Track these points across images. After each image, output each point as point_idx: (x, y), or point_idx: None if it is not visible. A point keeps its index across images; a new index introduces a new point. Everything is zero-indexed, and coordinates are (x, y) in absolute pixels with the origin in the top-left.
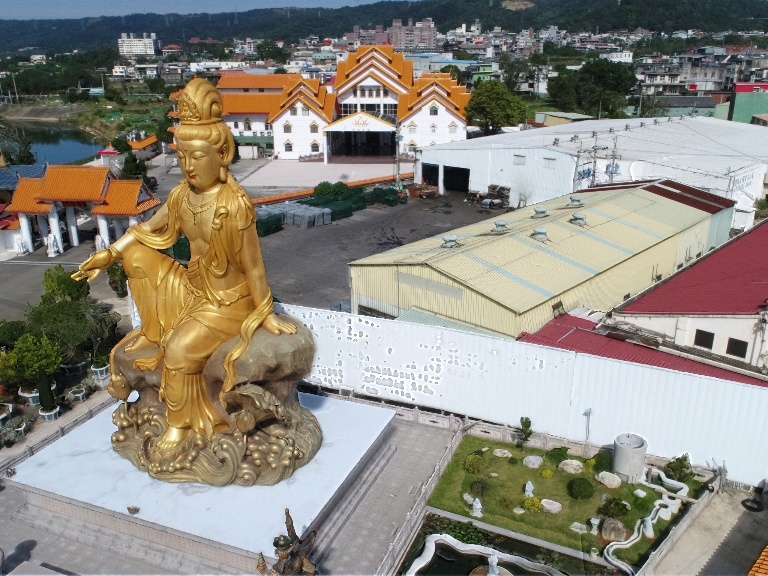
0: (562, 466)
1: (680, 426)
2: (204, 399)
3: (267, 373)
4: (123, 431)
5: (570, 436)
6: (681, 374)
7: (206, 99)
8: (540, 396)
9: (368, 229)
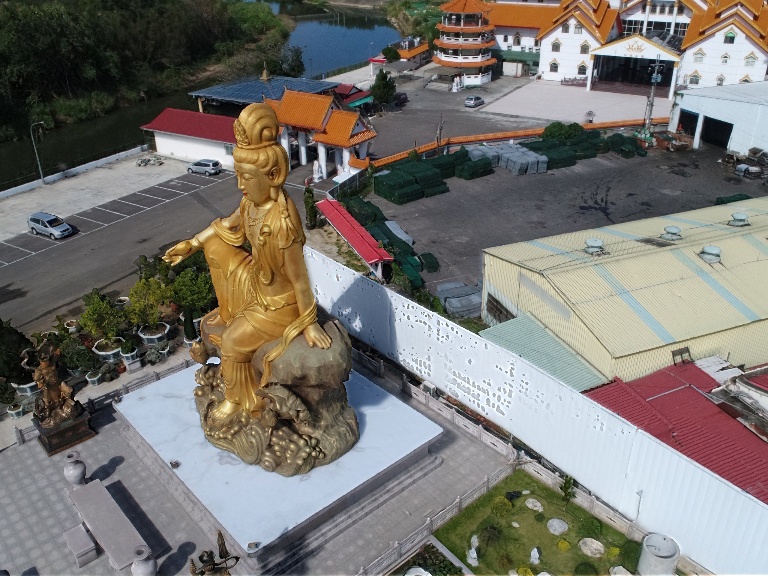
0: (581, 543)
1: (734, 548)
2: (252, 384)
3: (295, 379)
4: (203, 387)
5: (622, 508)
6: (743, 495)
7: (256, 125)
8: (598, 457)
9: (581, 185)
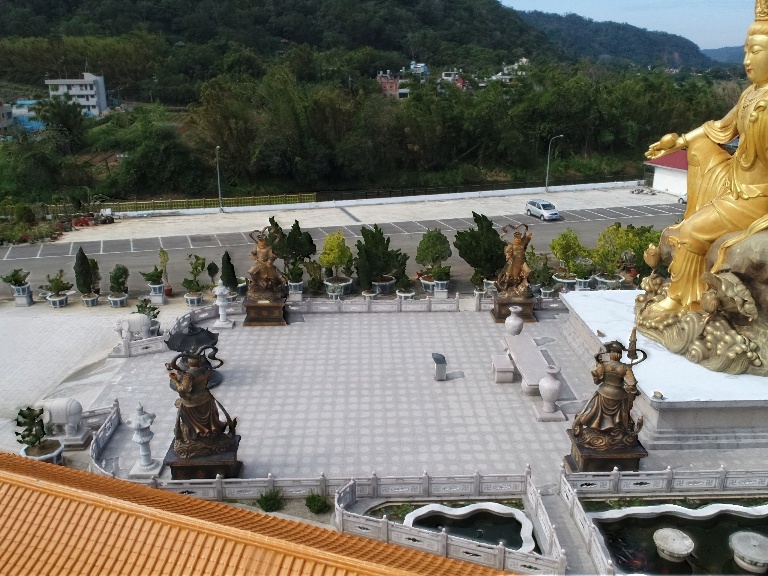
0: None
1: None
2: (700, 281)
3: (751, 268)
4: (646, 295)
5: None
6: None
7: None
8: None
9: None
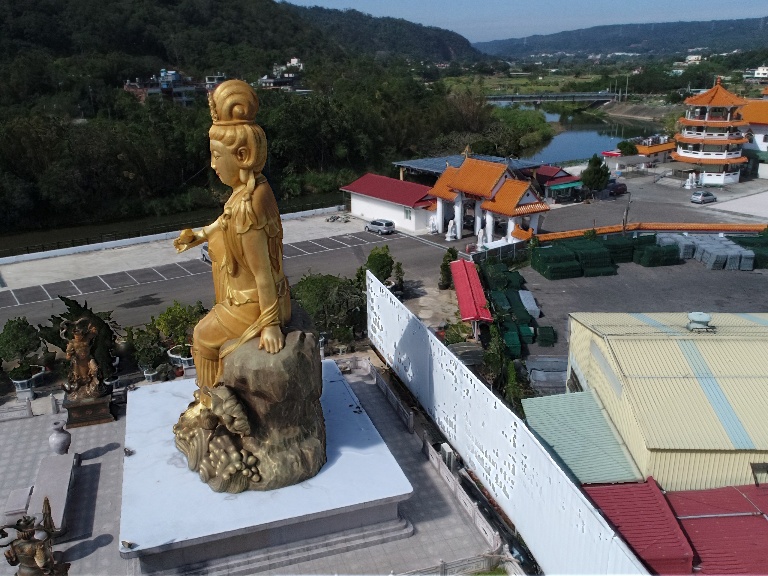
0: None
1: None
2: None
3: (239, 382)
4: None
5: None
6: None
7: (227, 100)
8: (579, 571)
9: None
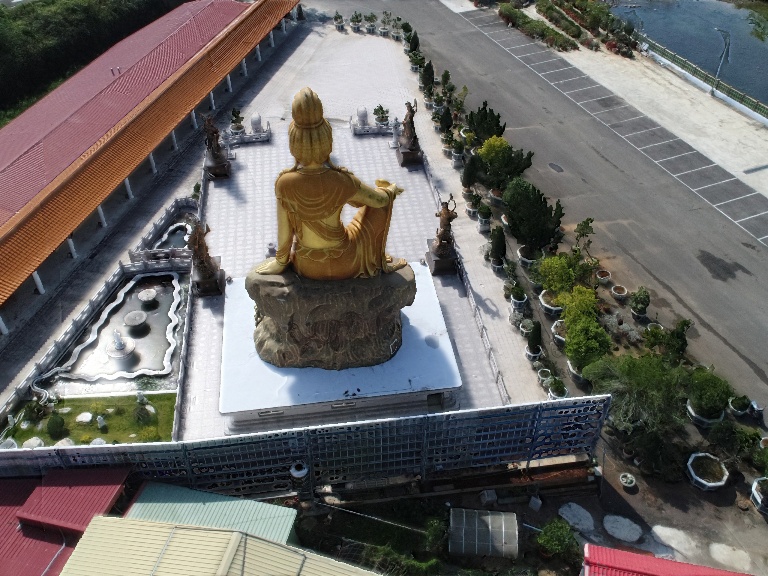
0: None
1: None
2: None
3: None
4: None
5: None
6: None
7: None
8: None
9: None
